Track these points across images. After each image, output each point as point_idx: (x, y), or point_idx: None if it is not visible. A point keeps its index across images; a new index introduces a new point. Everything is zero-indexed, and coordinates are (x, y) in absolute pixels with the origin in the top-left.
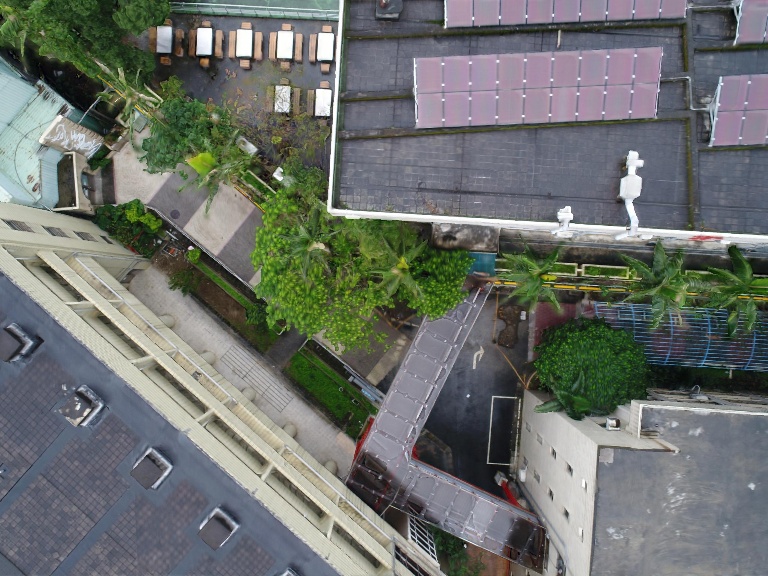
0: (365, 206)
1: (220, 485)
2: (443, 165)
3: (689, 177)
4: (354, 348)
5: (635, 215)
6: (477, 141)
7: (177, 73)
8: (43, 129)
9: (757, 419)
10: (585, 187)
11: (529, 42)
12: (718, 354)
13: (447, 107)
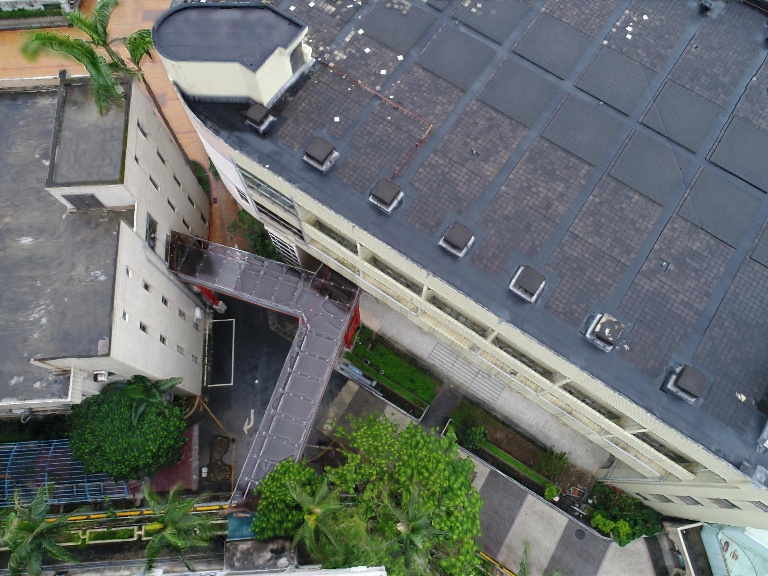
0: None
1: (462, 277)
2: None
3: None
4: None
5: None
6: None
7: None
8: None
9: None
10: None
11: None
12: None
13: None
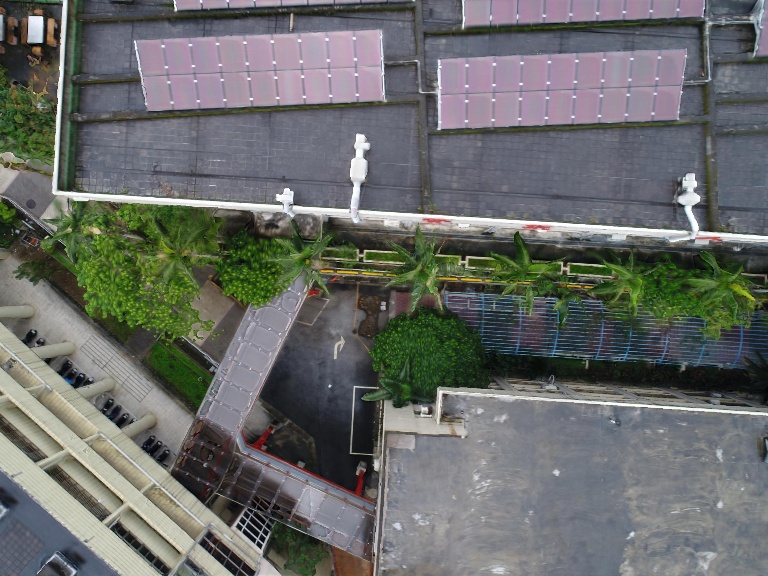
0: (101, 189)
1: None
2: (178, 148)
3: (421, 160)
4: (215, 338)
5: (355, 197)
6: (211, 124)
7: (11, 61)
8: None
9: (562, 406)
10: (319, 170)
11: (263, 25)
12: (567, 344)
13: (174, 90)
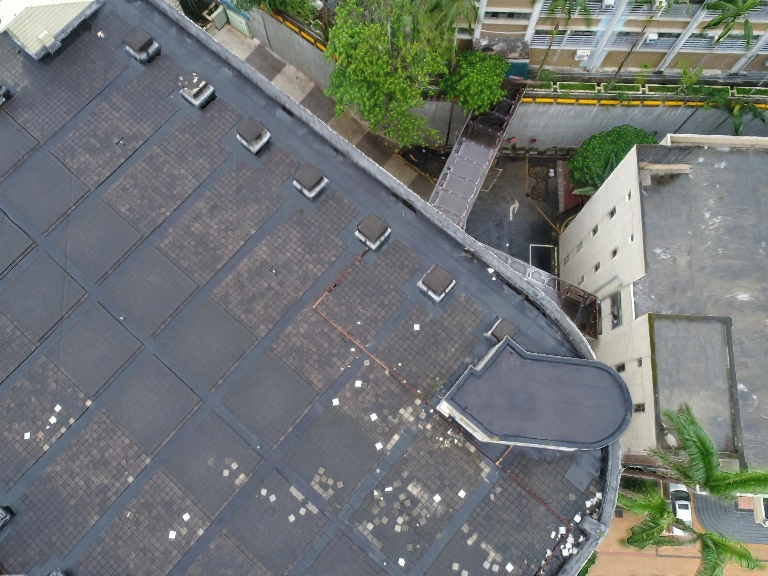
0: None
1: (311, 149)
2: None
3: None
4: None
5: None
6: None
7: None
8: None
9: None
10: None
11: None
12: None
13: None
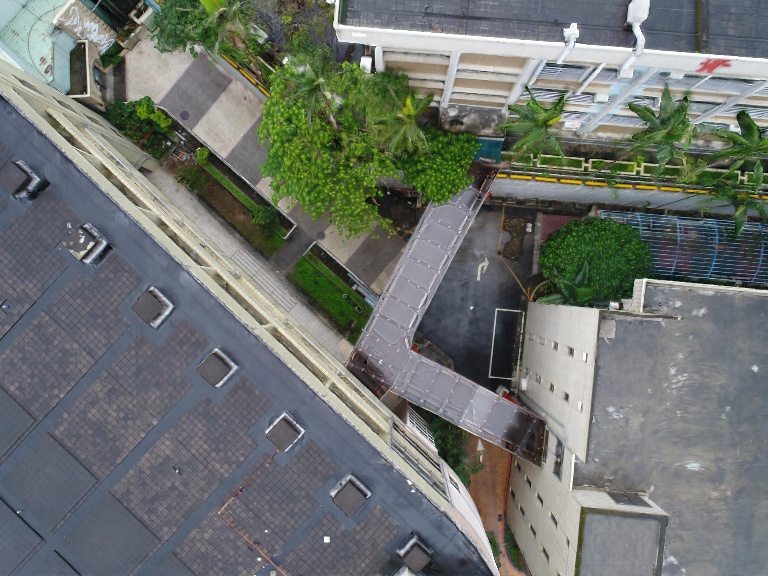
0: None
1: (220, 326)
2: None
3: (698, 5)
4: (359, 256)
5: None
6: None
7: None
8: (57, 12)
9: (762, 301)
10: (592, 14)
11: None
12: (725, 264)
13: None
